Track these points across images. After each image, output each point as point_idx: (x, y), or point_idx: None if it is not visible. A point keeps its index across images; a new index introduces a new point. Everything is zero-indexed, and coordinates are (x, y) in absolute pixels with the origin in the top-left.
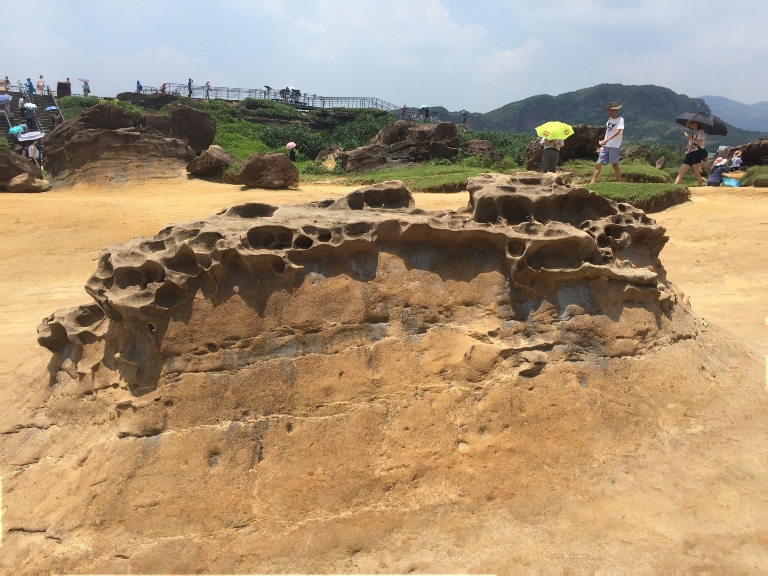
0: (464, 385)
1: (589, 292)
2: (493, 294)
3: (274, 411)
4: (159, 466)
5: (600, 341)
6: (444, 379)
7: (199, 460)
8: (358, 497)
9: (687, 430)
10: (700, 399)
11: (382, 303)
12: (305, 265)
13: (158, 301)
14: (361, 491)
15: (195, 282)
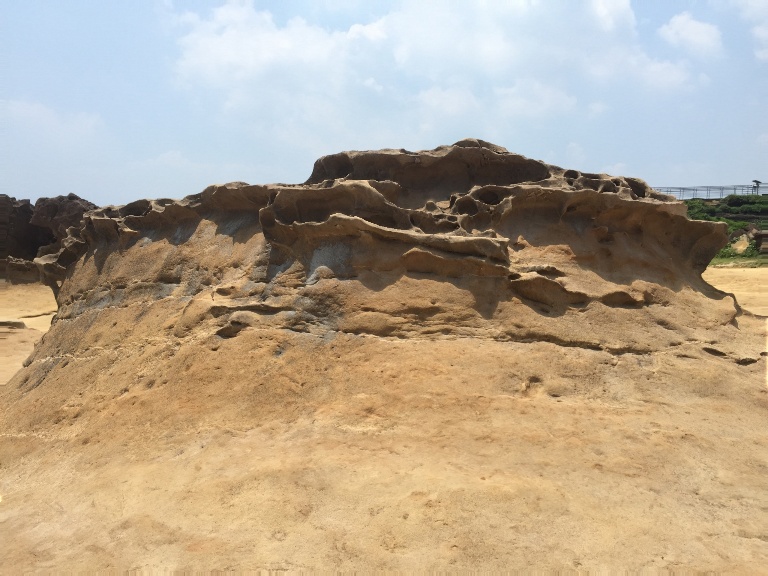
0: (170, 339)
1: (349, 252)
2: (254, 254)
3: (68, 351)
4: (6, 385)
5: (339, 311)
6: (168, 334)
7: (17, 383)
8: (39, 424)
9: (345, 426)
10: (422, 398)
11: (180, 265)
12: (144, 231)
13: (64, 262)
14: (44, 419)
15: (85, 247)
